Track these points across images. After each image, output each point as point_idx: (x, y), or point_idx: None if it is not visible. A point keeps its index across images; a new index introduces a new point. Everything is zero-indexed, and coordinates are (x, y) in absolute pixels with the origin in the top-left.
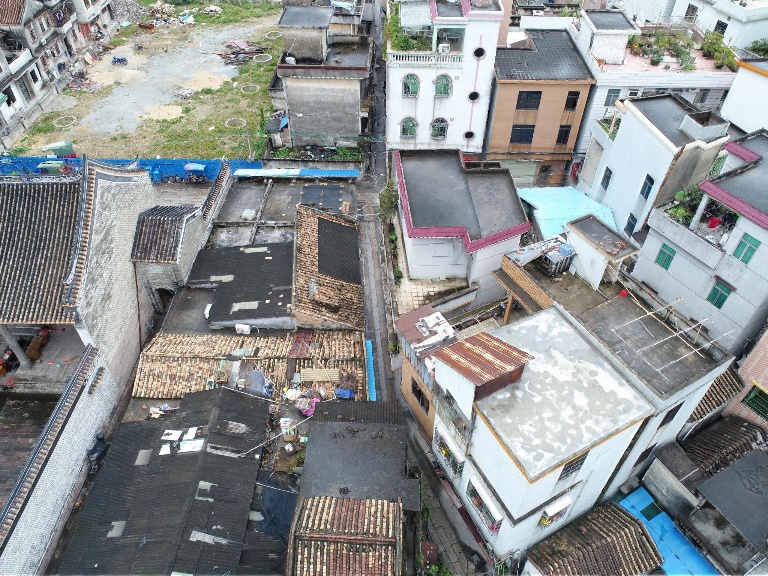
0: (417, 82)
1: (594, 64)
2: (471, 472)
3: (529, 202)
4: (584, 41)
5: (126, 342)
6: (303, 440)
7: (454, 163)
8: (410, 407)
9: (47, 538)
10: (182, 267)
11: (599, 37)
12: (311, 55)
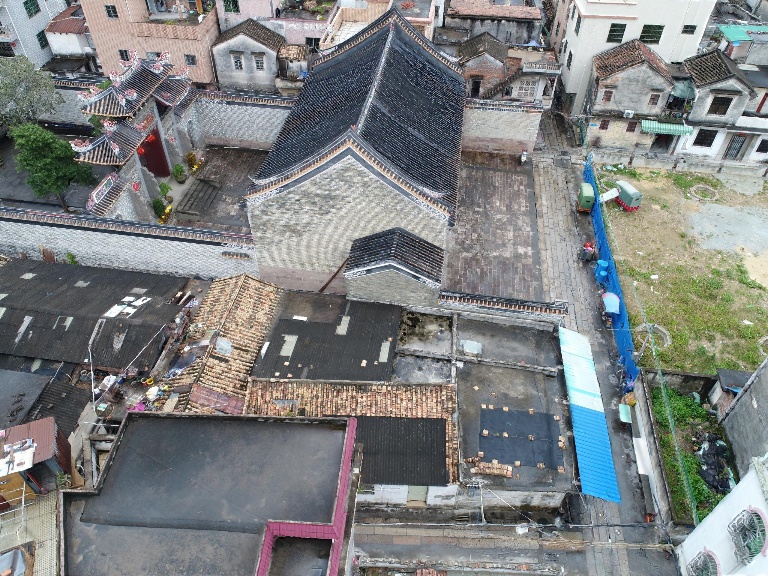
0: (757, 544)
1: None
2: None
3: None
4: None
5: (297, 276)
6: (101, 405)
7: (305, 515)
8: None
9: (131, 266)
10: (355, 286)
11: None
12: None
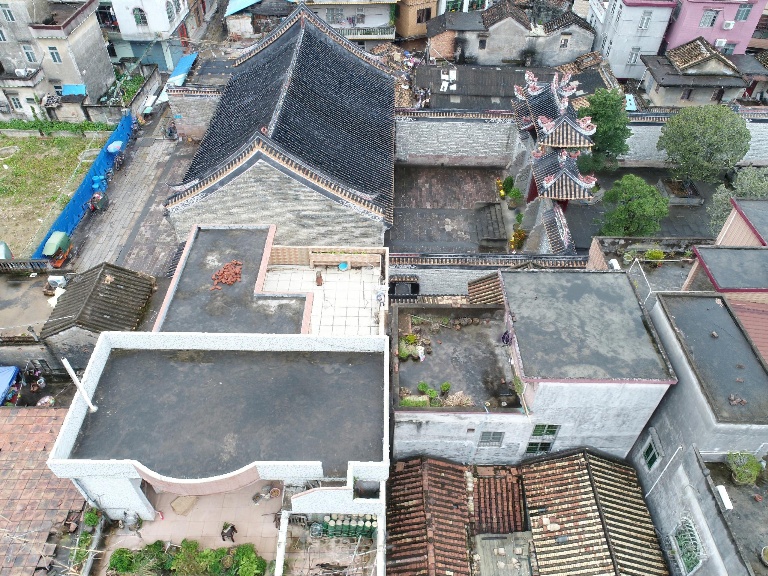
0: None
1: None
2: None
3: (256, 2)
4: None
5: None
6: None
7: None
8: (418, 34)
9: None
10: None
11: None
12: (45, 16)
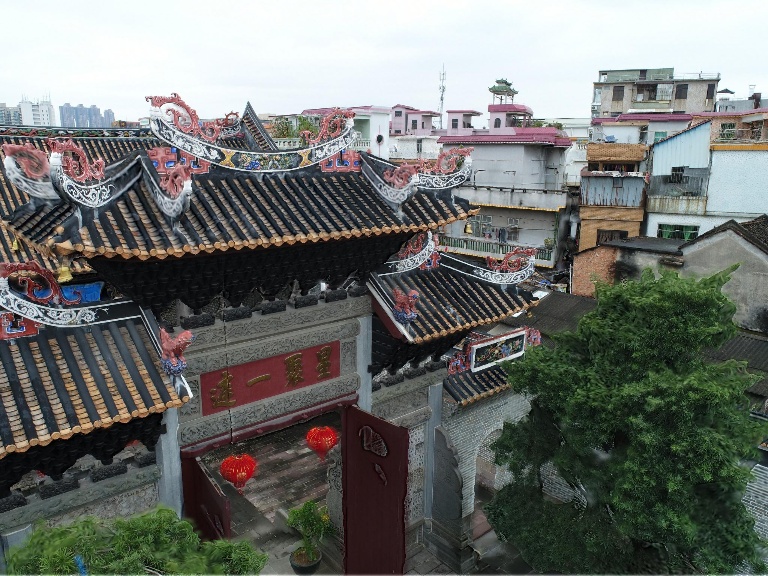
0: None
1: (435, 153)
2: None
3: None
4: (409, 153)
5: None
6: None
7: None
8: None
9: None
10: None
11: (426, 141)
12: None
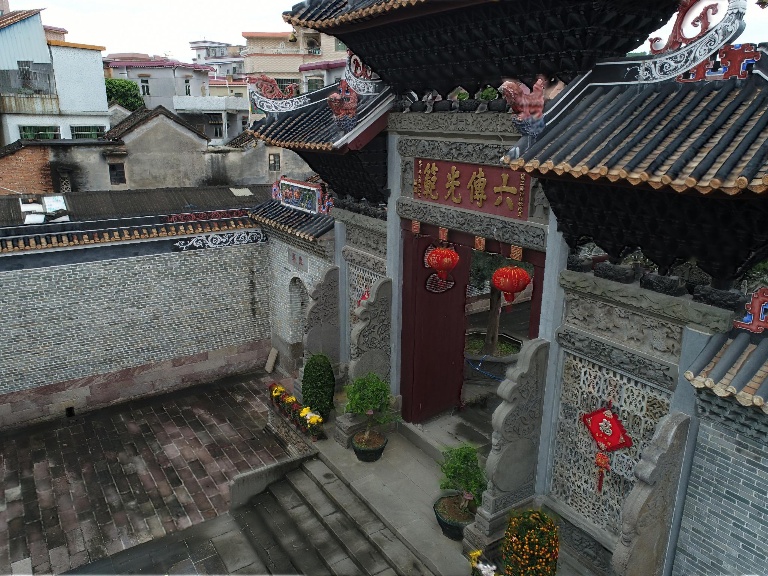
0: None
1: None
2: (66, 130)
3: None
4: None
5: None
6: None
7: None
8: None
9: None
10: None
11: None
12: None
